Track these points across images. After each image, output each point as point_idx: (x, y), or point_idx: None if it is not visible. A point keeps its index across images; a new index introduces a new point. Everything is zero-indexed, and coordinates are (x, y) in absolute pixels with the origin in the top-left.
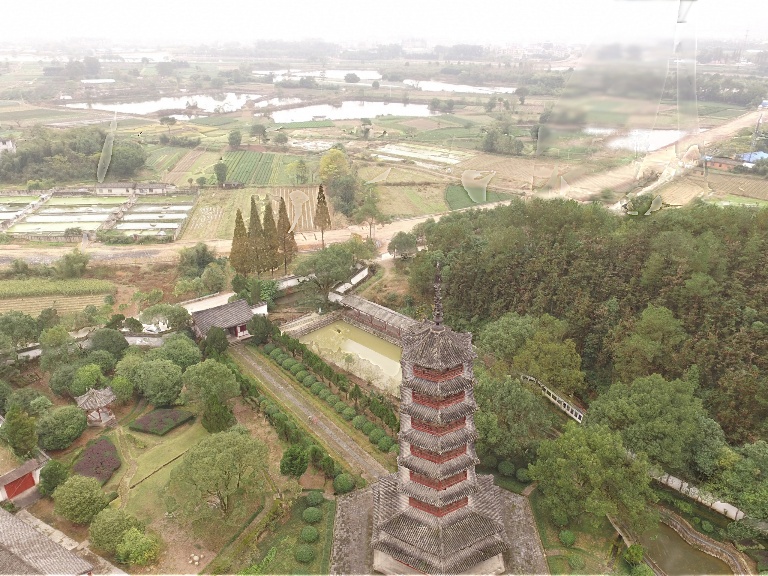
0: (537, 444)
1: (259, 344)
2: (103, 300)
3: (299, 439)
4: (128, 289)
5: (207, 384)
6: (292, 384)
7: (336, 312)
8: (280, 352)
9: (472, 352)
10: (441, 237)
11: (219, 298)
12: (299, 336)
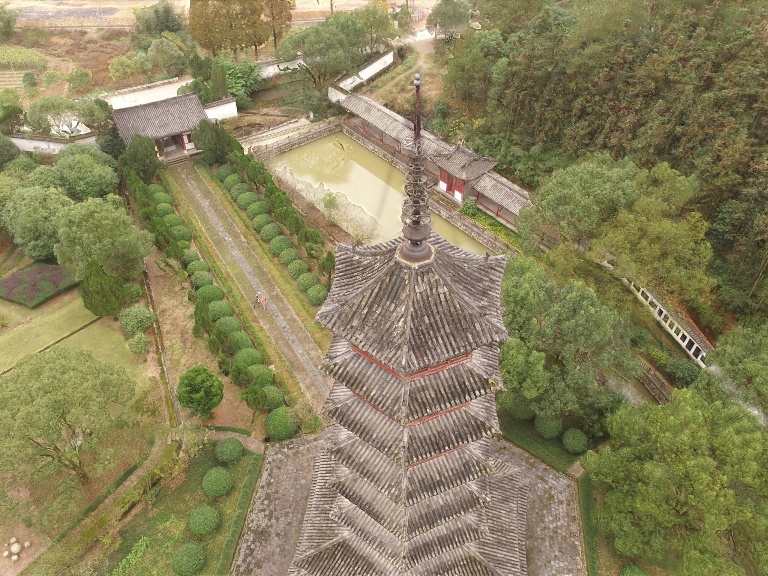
0: (607, 401)
1: (213, 164)
2: (22, 79)
3: (224, 340)
4: (62, 64)
5: (84, 242)
6: (245, 234)
7: (333, 119)
8: (237, 180)
9: (495, 325)
10: (503, 7)
11: (177, 86)
12: (275, 154)
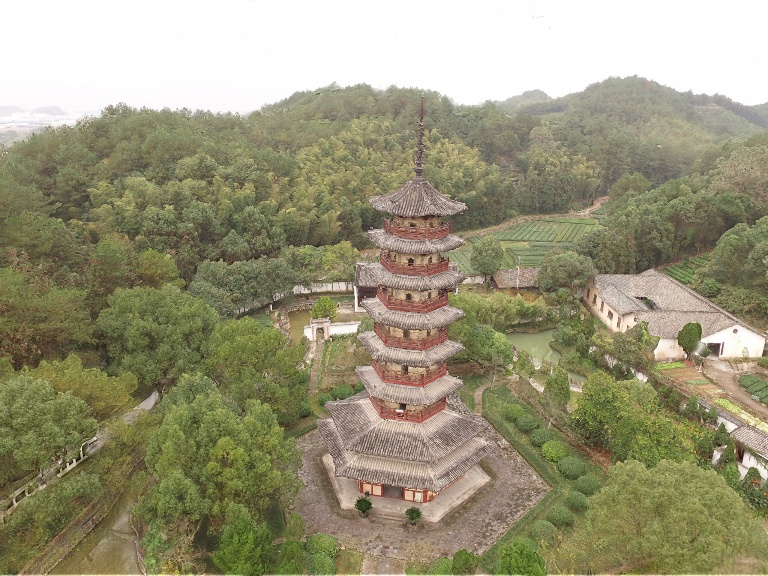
0: None
1: None
2: None
3: None
4: None
5: None
6: None
7: None
8: None
9: None
10: None
11: None
12: None
